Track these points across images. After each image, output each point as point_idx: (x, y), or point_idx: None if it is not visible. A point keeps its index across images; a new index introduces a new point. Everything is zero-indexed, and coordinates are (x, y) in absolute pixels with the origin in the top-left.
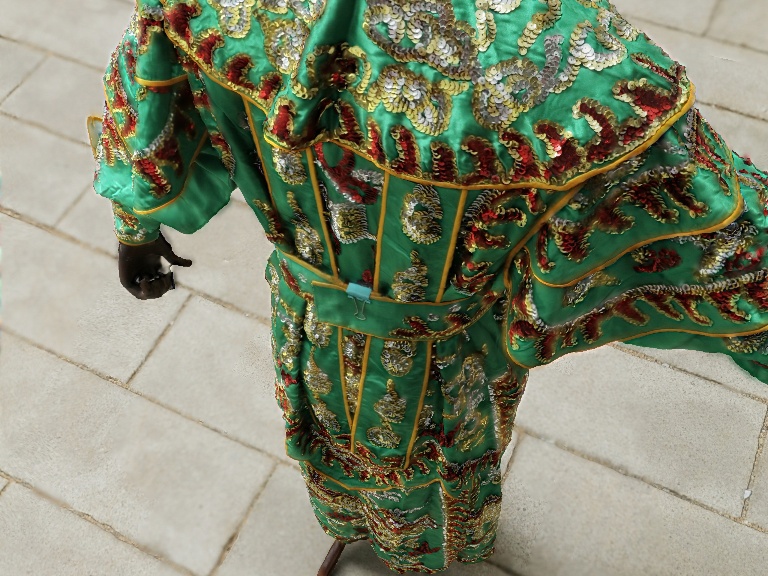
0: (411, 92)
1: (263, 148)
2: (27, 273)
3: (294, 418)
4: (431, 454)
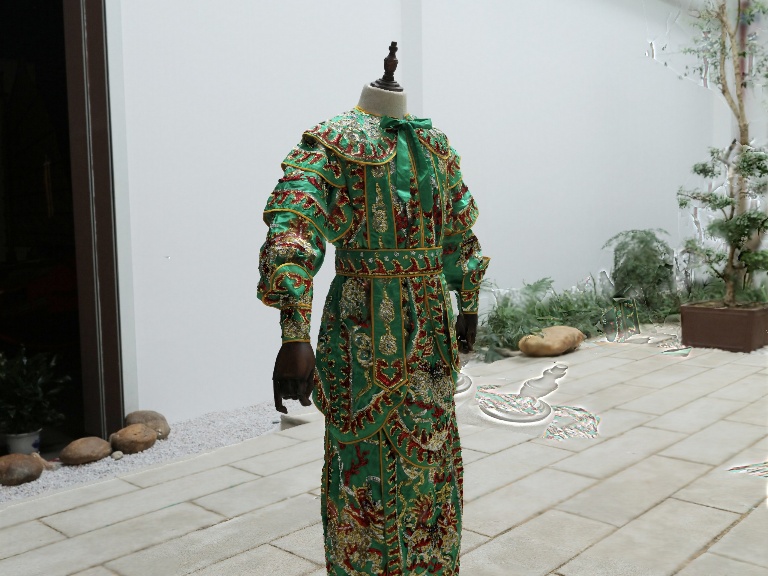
0: None
1: None
2: None
3: None
4: None
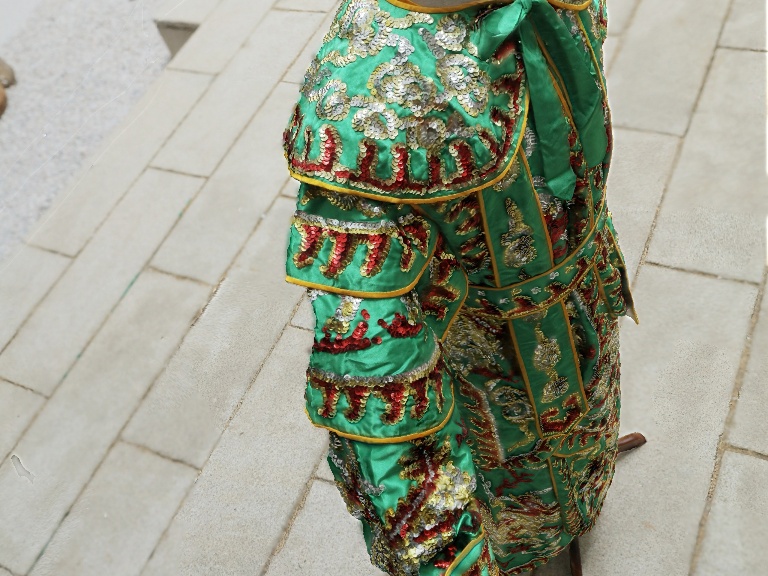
0: None
1: None
2: (739, 153)
3: None
4: None
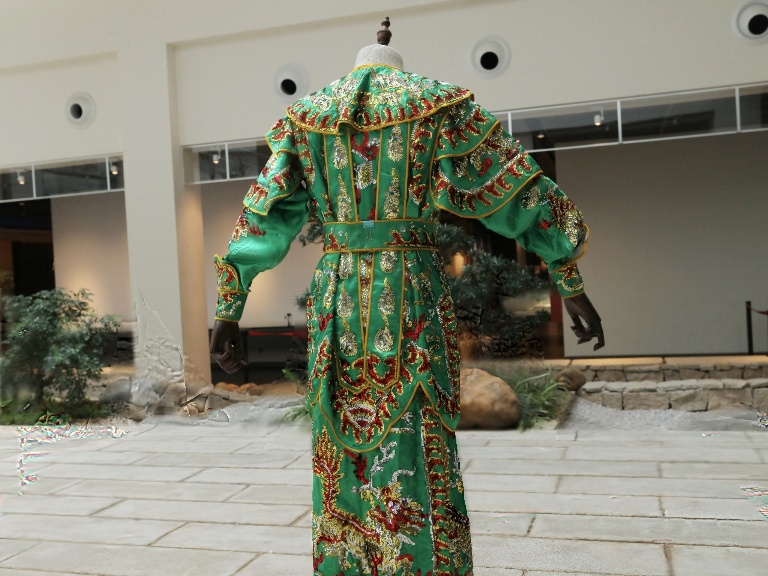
0: (388, 96)
1: (329, 161)
2: None
3: (329, 353)
4: (412, 358)
